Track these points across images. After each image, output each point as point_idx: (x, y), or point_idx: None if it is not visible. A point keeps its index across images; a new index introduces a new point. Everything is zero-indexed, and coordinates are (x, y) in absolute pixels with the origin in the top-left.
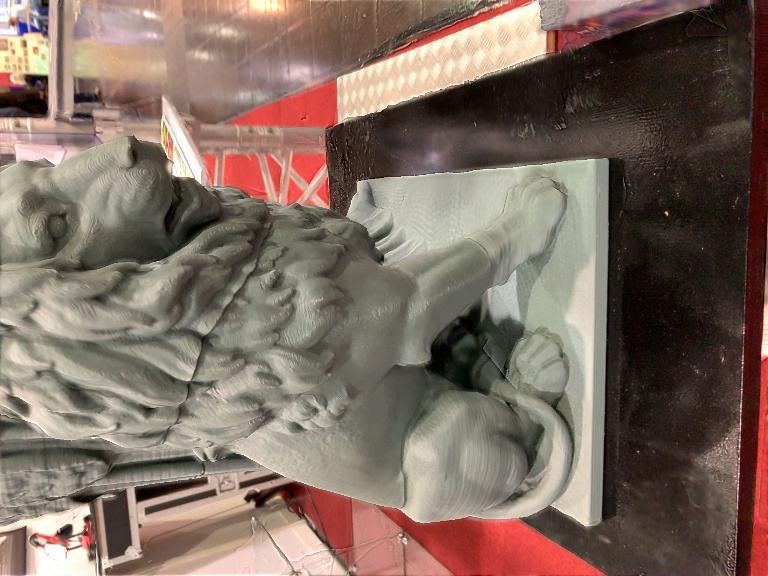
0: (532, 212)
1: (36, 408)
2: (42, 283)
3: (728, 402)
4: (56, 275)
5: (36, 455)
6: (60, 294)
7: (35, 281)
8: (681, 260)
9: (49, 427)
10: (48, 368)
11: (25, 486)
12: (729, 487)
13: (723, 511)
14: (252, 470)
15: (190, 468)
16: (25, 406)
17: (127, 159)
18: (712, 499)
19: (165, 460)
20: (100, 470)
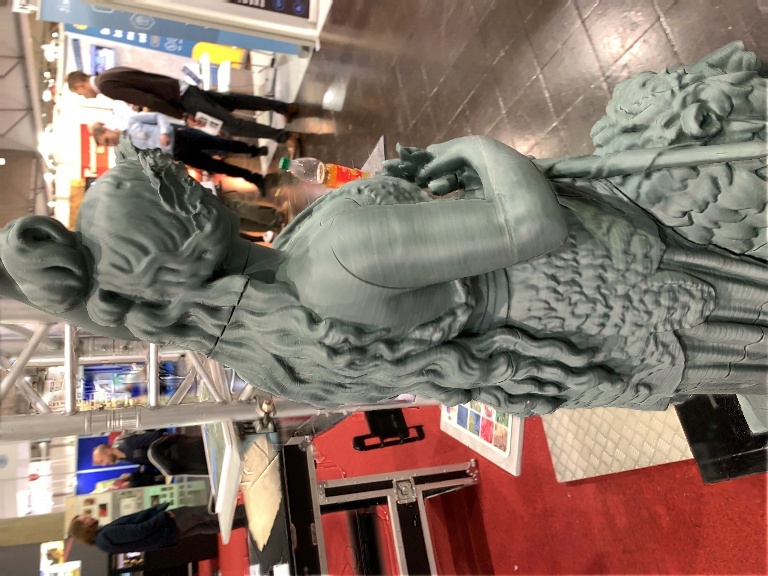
0: None
1: (738, 175)
2: (752, 77)
3: None
4: (758, 74)
5: (683, 273)
6: (763, 83)
7: (750, 75)
8: None
9: (746, 190)
10: (758, 131)
11: (676, 303)
12: None
13: None
14: (767, 375)
15: (753, 330)
16: (731, 174)
17: (744, 46)
18: None
19: (735, 320)
20: (714, 301)
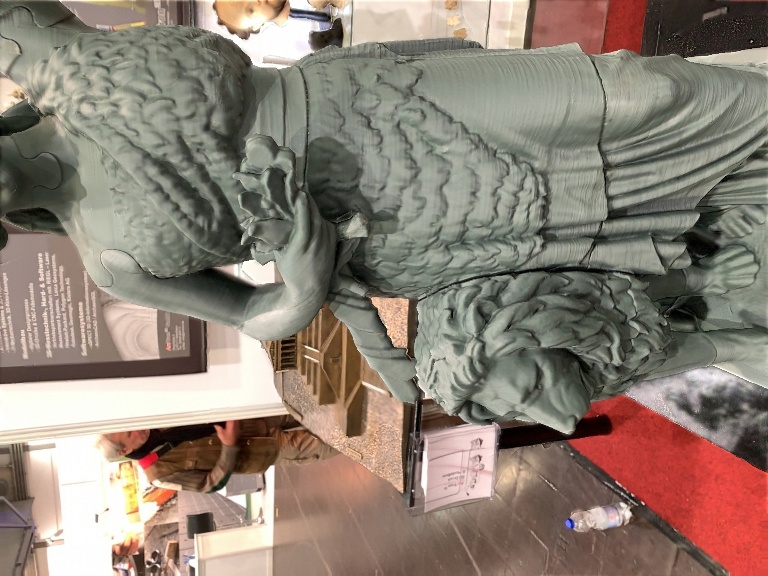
0: (764, 369)
1: None
2: None
3: (684, 421)
4: None
5: None
6: None
7: None
8: (749, 428)
9: None
10: None
11: None
12: (652, 405)
13: (642, 398)
14: None
15: None
16: None
17: None
18: (646, 395)
19: None
20: None
